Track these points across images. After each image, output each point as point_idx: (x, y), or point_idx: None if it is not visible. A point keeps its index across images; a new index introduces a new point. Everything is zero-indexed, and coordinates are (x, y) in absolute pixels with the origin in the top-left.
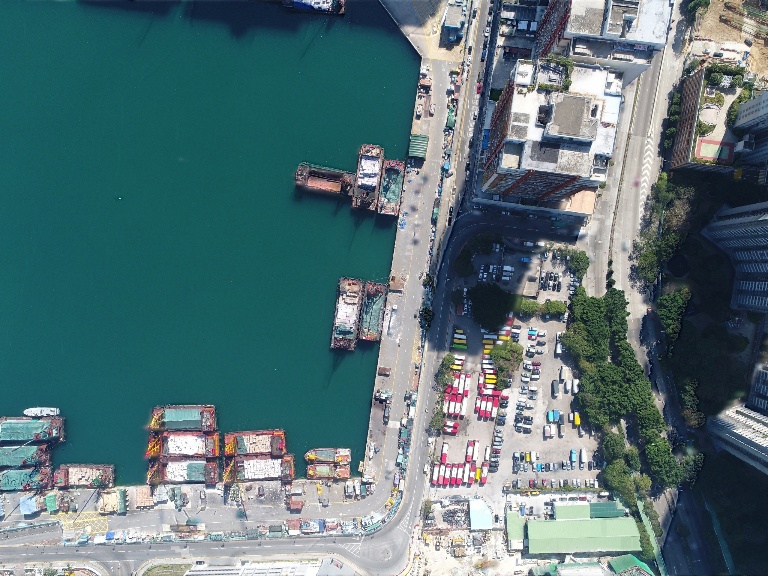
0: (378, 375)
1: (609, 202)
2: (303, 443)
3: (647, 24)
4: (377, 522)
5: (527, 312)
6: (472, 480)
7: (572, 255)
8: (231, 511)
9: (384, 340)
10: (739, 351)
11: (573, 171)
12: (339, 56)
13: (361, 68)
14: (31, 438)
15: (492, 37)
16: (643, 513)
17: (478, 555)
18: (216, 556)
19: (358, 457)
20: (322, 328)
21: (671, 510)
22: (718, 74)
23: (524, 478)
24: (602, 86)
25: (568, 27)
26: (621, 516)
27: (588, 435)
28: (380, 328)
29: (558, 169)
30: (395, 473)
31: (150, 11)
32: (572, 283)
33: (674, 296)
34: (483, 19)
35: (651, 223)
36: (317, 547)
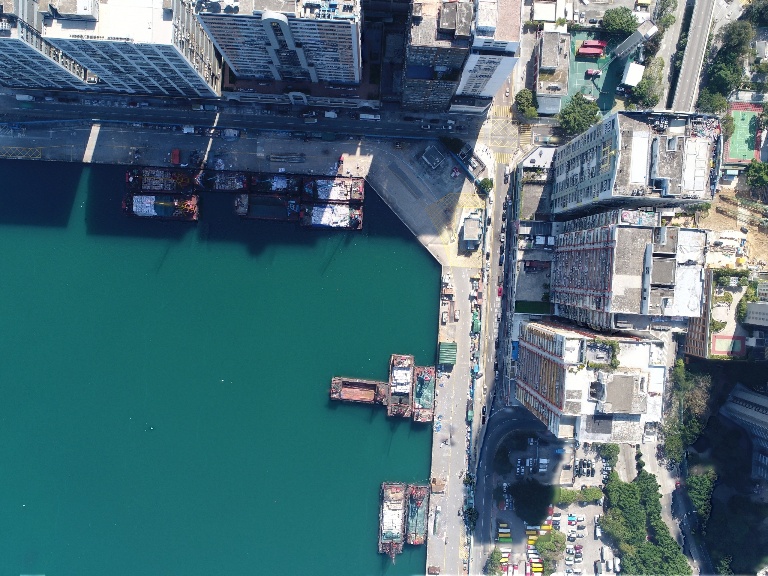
0: (428, 574)
1: None
2: None
3: (682, 299)
4: None
5: (566, 503)
6: None
7: (604, 445)
8: None
9: (431, 540)
10: (764, 519)
11: (626, 439)
12: (361, 269)
13: (383, 279)
14: None
15: (508, 242)
16: None
17: None
18: None
19: None
20: (368, 533)
21: None
22: (726, 277)
23: None
24: (646, 359)
25: (610, 308)
26: None
27: None
28: (425, 528)
29: (612, 439)
30: None
31: (165, 238)
32: (605, 468)
33: (703, 479)
34: (497, 225)
35: (672, 404)
36: None
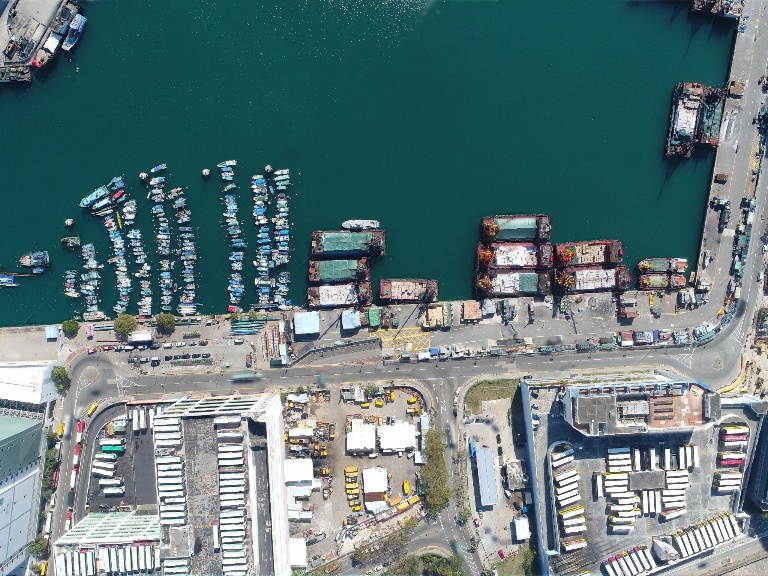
0: (714, 182)
1: None
2: (633, 254)
3: None
4: (711, 331)
5: None
6: None
7: None
8: (560, 324)
9: (721, 147)
10: None
11: None
12: None
13: None
14: (357, 248)
15: None
16: None
17: None
18: (544, 370)
19: (689, 268)
20: (655, 136)
21: None
22: None
23: None
24: None
25: None
26: None
27: None
28: None
29: None
30: (729, 282)
31: None
32: None
33: None
34: None
35: None
36: (648, 359)
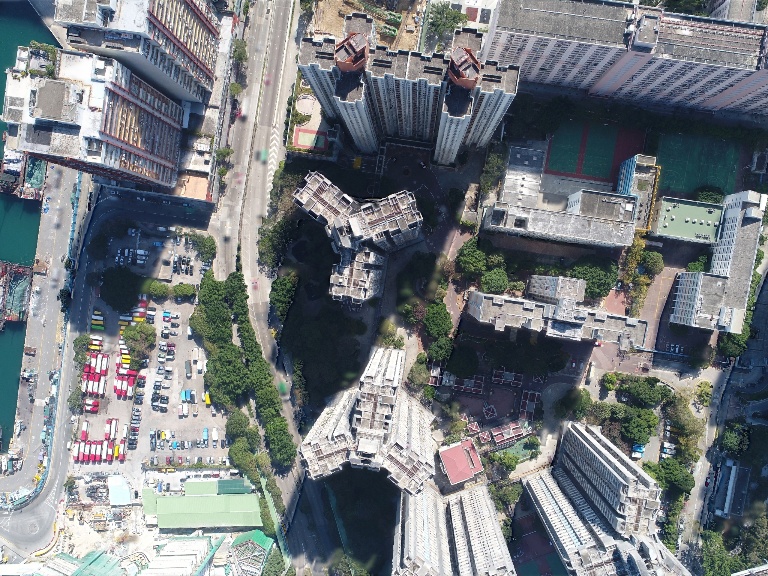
0: (25, 355)
1: (238, 189)
2: None
3: (128, 14)
4: (23, 497)
5: (155, 294)
6: (110, 457)
7: (196, 240)
8: None
9: (30, 321)
10: (351, 334)
11: (65, 153)
12: None
13: (7, 58)
14: None
15: None
16: (266, 490)
17: (119, 530)
18: None
19: (9, 434)
20: None
21: (298, 487)
22: None
23: (162, 455)
24: (89, 72)
25: (56, 16)
26: (248, 493)
27: (221, 414)
28: (27, 309)
29: (51, 151)
30: (41, 450)
31: None
32: (203, 267)
33: (282, 279)
34: None
35: (278, 210)
36: None
